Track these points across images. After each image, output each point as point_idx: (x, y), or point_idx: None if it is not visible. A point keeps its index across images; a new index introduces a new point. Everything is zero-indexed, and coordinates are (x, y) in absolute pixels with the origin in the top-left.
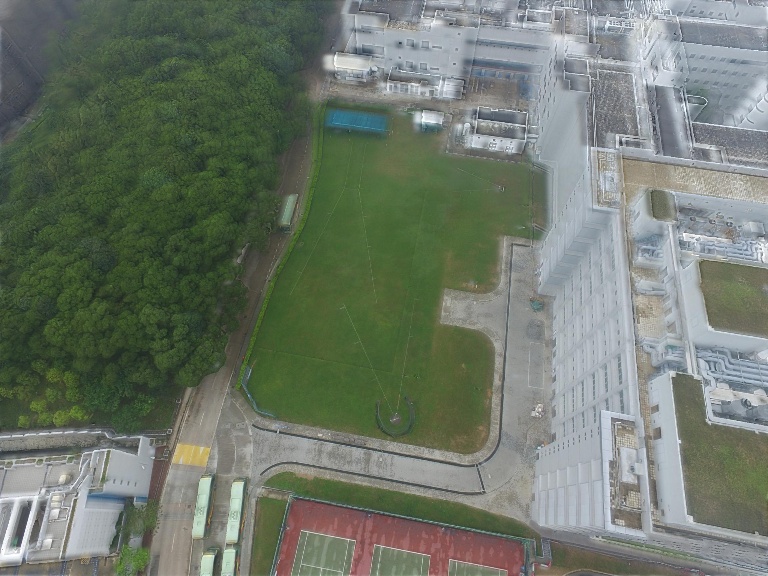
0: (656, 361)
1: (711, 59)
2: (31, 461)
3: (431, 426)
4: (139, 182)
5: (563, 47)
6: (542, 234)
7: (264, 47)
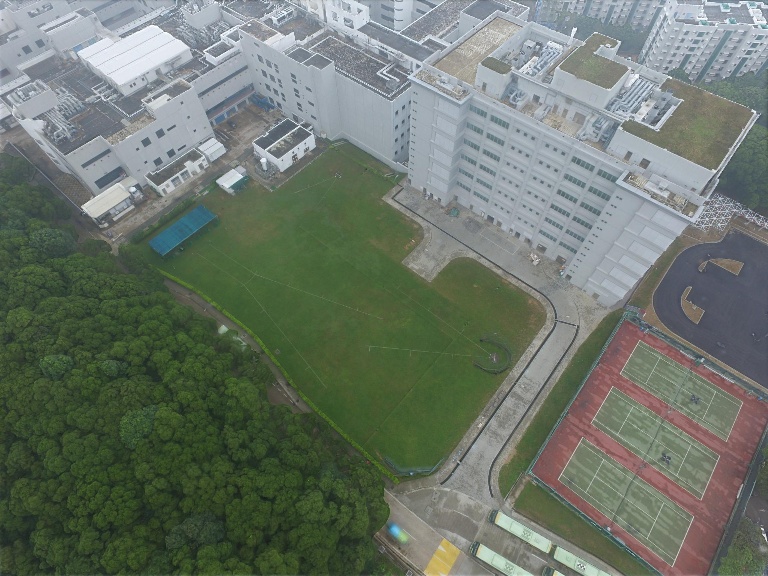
0: (595, 138)
1: None
2: None
3: (513, 335)
4: (122, 452)
5: (276, 50)
6: None
7: (26, 253)
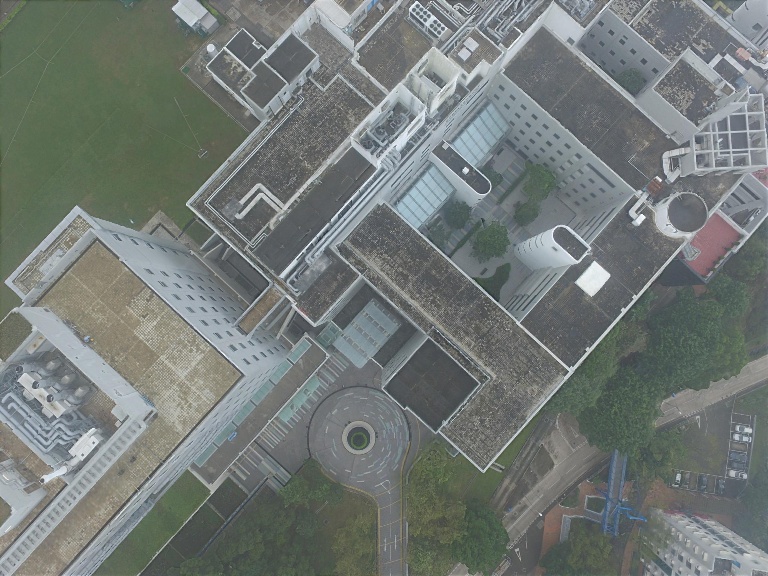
0: None
1: (555, 136)
2: None
3: None
4: None
5: None
6: (201, 231)
7: None
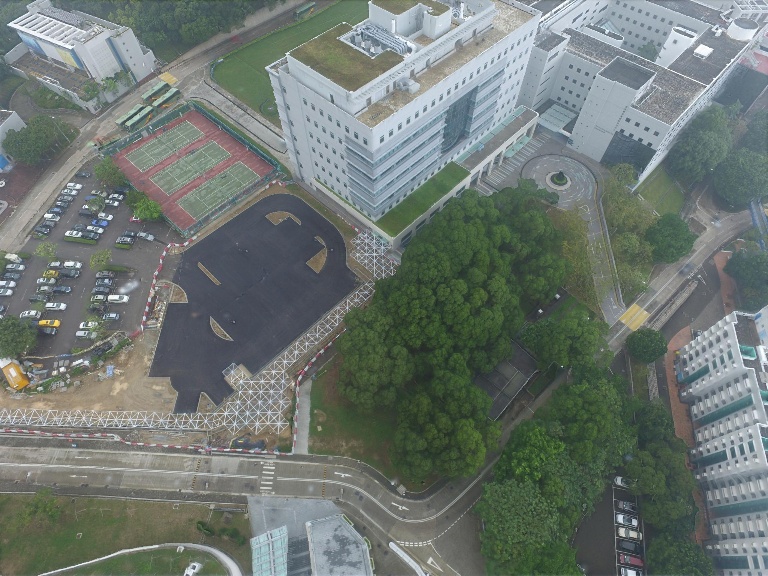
0: None
1: (654, 17)
2: (102, 26)
3: None
4: None
5: None
6: None
7: None
